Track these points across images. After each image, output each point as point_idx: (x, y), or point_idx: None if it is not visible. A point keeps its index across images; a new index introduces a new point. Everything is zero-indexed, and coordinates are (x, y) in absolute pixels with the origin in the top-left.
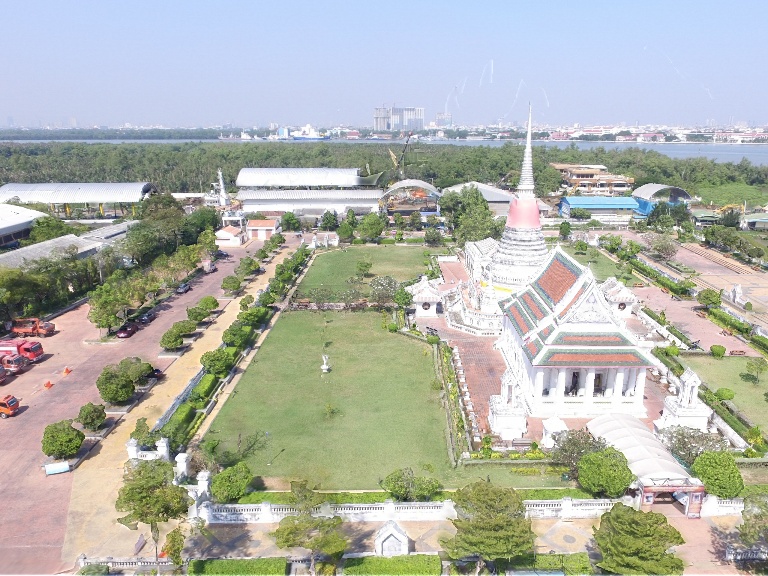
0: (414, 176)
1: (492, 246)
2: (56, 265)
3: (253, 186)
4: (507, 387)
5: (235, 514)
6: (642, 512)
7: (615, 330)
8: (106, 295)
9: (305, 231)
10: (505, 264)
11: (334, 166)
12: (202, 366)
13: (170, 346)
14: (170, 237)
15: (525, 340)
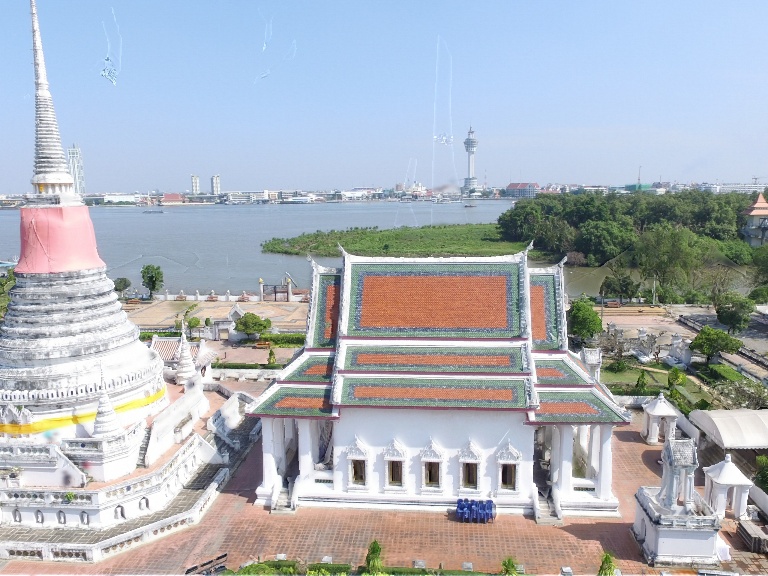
0: None
1: None
2: None
3: None
4: None
5: None
6: None
7: None
8: None
9: None
10: (86, 356)
11: None
12: None
13: None
14: None
15: None
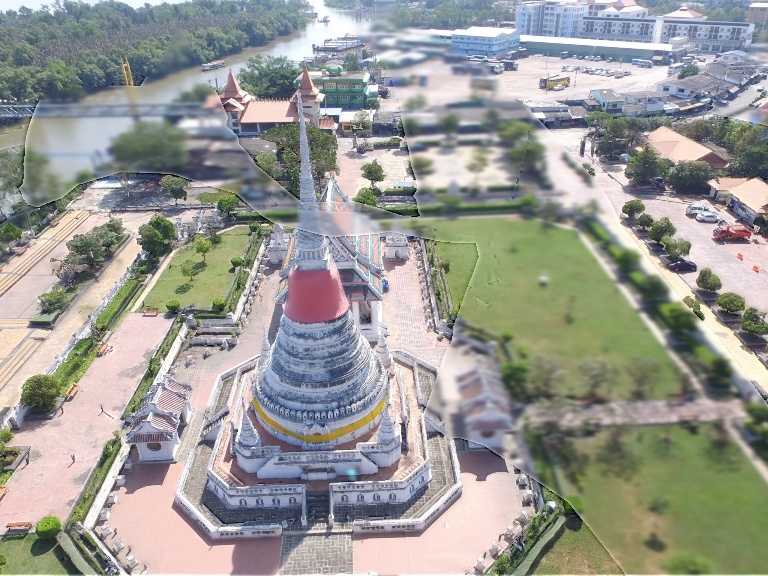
0: None
1: None
2: None
3: None
4: None
5: None
6: (372, 166)
7: None
8: None
9: None
10: None
11: None
12: None
13: None
14: None
15: None
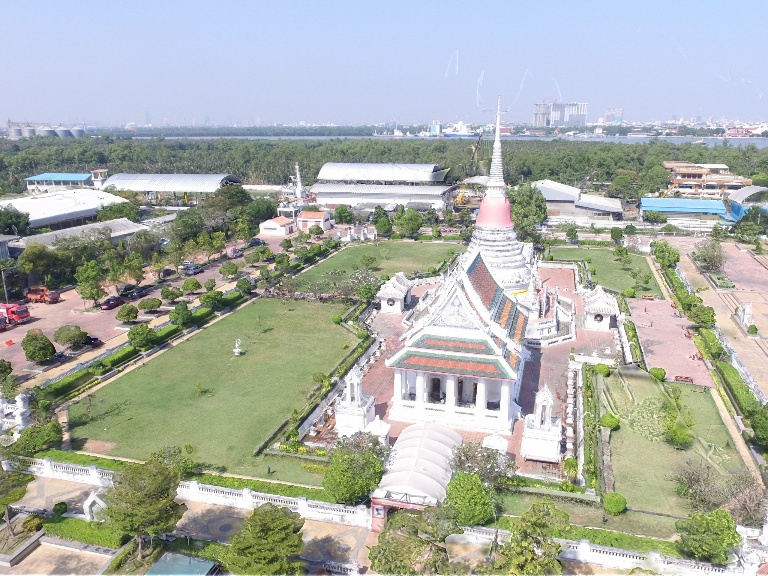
0: (485, 173)
1: None
2: (82, 243)
3: (333, 180)
4: (350, 384)
5: (25, 465)
6: (278, 515)
7: (483, 337)
8: (91, 271)
9: (357, 224)
10: None
11: (389, 161)
12: None
13: (123, 319)
14: (218, 224)
15: (402, 340)
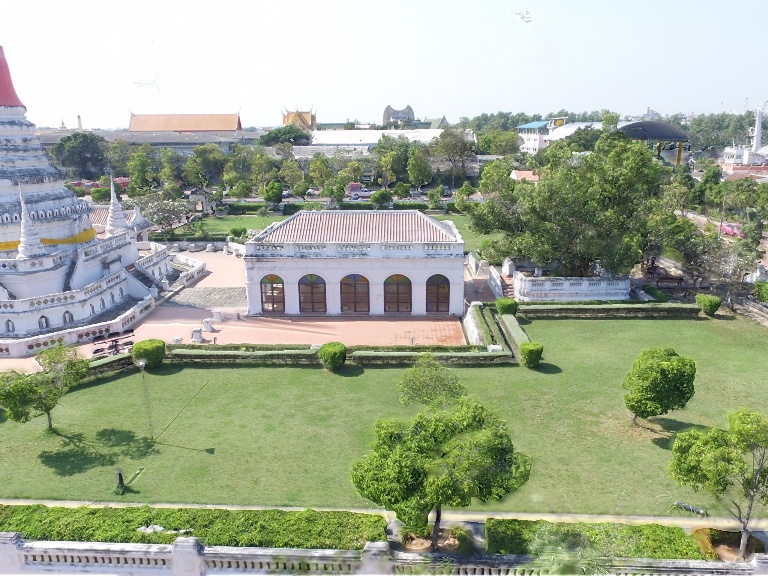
0: None
1: None
2: None
3: None
4: None
5: None
6: None
7: None
8: None
9: None
10: None
11: None
12: None
13: None
14: None
15: None
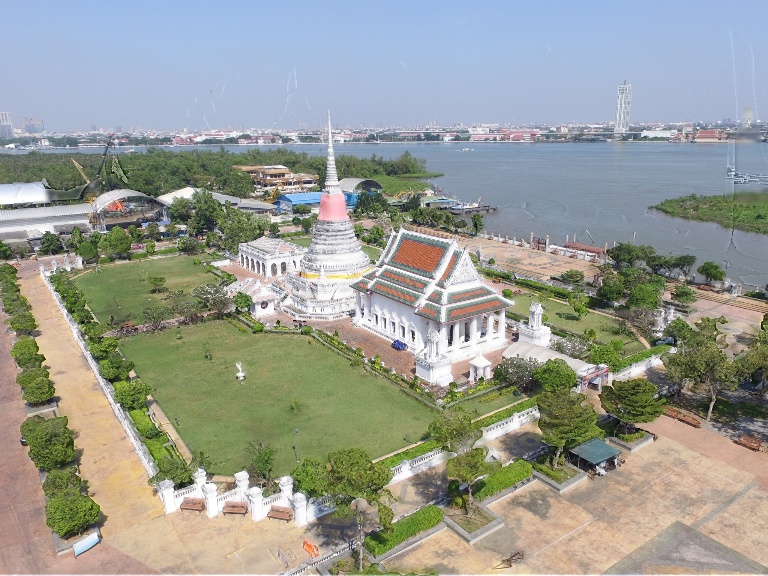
0: (122, 186)
1: (275, 243)
2: None
3: None
4: (435, 344)
5: None
6: None
7: (480, 285)
8: None
9: (19, 258)
10: (328, 254)
11: (43, 179)
12: (117, 405)
13: (44, 398)
14: None
15: (417, 307)
